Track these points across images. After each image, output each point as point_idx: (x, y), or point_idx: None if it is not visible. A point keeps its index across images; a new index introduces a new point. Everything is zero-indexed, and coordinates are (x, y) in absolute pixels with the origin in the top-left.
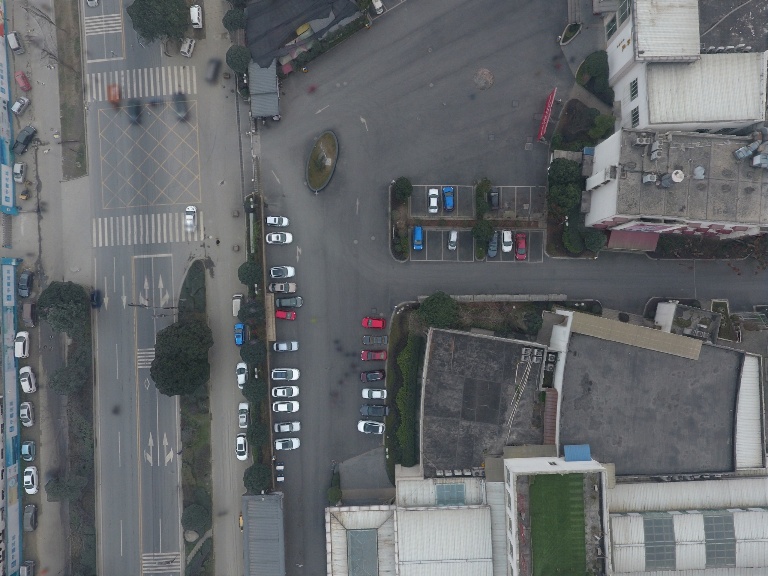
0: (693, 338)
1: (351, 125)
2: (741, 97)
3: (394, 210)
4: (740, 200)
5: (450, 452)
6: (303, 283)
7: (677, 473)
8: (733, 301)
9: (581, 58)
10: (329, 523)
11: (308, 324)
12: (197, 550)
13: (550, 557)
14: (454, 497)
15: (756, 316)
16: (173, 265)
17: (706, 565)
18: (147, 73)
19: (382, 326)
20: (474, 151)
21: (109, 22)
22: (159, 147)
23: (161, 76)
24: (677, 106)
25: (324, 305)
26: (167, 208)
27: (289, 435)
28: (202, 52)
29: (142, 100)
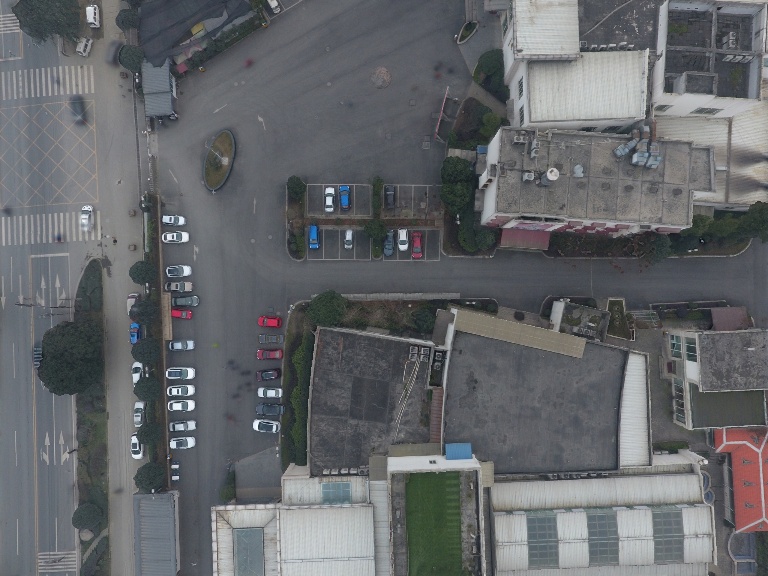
0: (577, 336)
1: (249, 124)
2: (622, 95)
3: (289, 209)
4: (620, 198)
5: (338, 451)
6: (200, 282)
7: (561, 471)
8: (629, 299)
9: (478, 57)
10: (215, 522)
11: (205, 323)
12: (93, 549)
13: (426, 555)
14: (340, 496)
15: (647, 314)
16: (70, 264)
17: (589, 563)
18: (44, 73)
19: (277, 325)
20: (371, 150)
21: (7, 22)
22: (56, 147)
23: (58, 76)
24: (558, 104)
25: (221, 304)
26: (64, 207)
27: (185, 434)
28: (100, 52)
29: (39, 100)
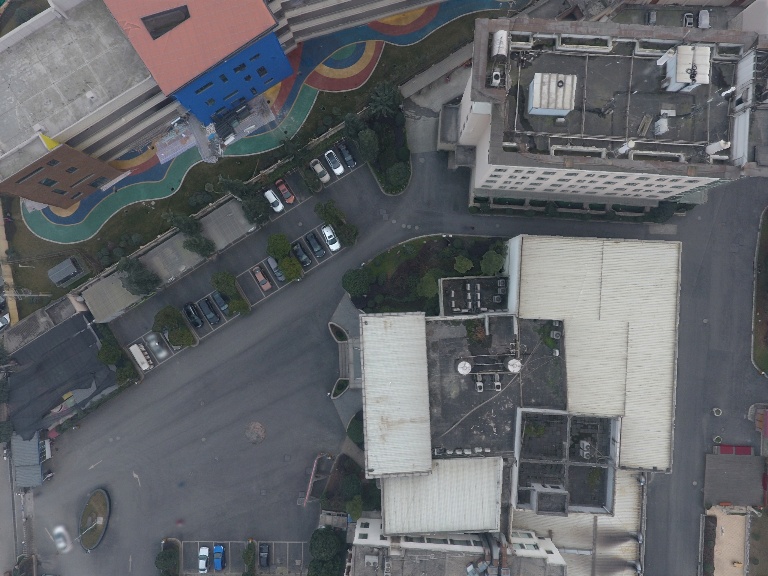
0: None
1: (124, 480)
2: (477, 505)
3: (162, 574)
4: None
5: None
6: None
7: None
8: None
9: (352, 412)
10: None
11: None
12: None
13: None
14: None
15: None
16: None
17: None
18: None
19: None
20: (246, 506)
21: None
22: None
23: None
24: (413, 515)
25: None
26: None
27: None
28: None
29: None
